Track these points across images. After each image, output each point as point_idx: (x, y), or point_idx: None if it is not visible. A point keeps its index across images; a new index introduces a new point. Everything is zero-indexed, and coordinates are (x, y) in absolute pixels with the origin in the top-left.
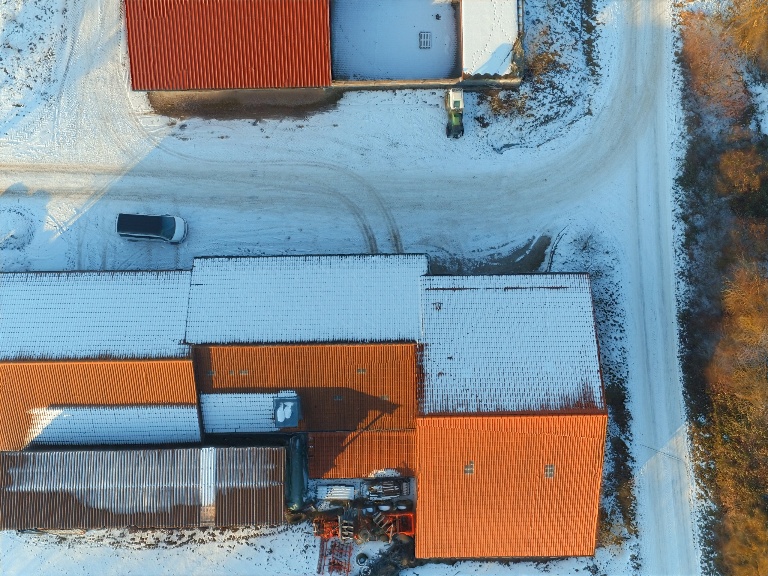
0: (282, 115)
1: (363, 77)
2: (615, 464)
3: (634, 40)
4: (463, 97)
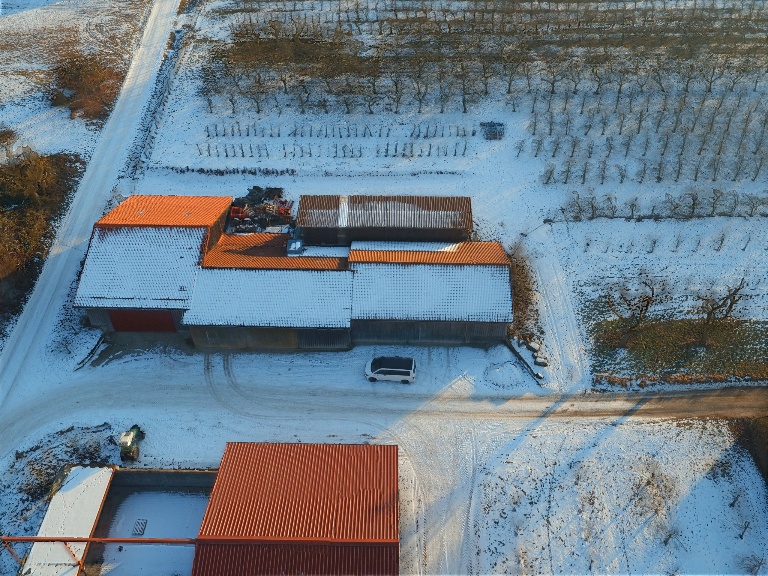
0: None
1: (207, 498)
2: None
3: None
4: None
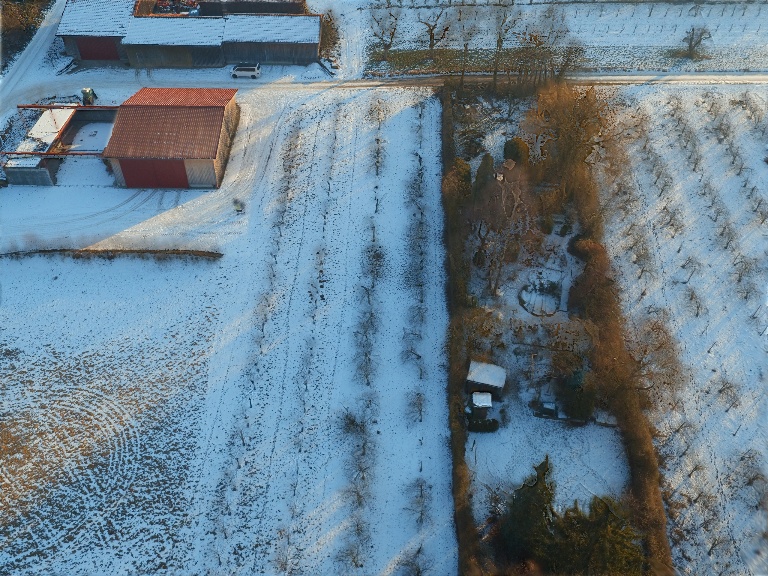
0: None
1: None
2: None
3: None
4: None
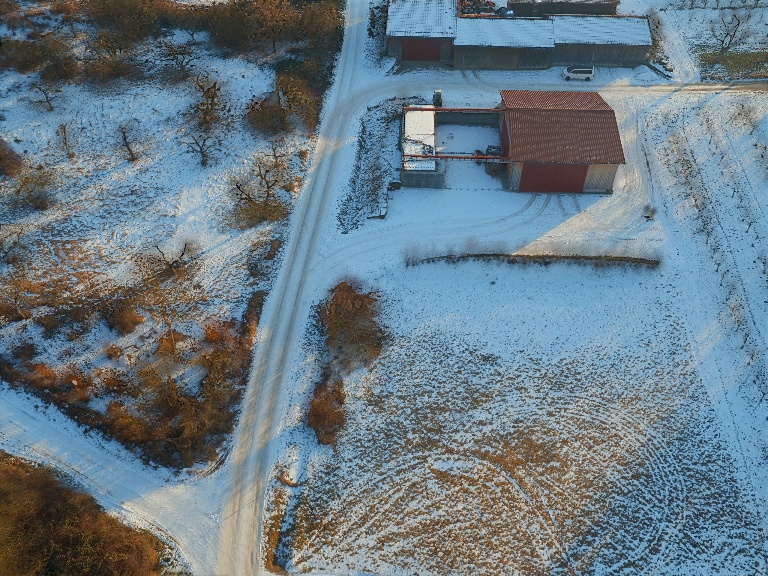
0: None
1: (483, 127)
2: (374, 24)
3: (340, 131)
4: None
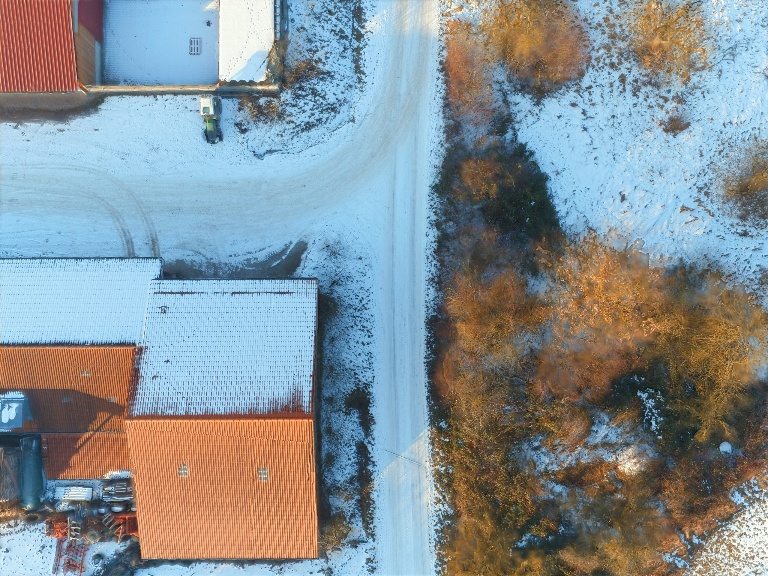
0: (43, 119)
1: (133, 82)
2: (359, 468)
3: (401, 49)
4: (215, 103)
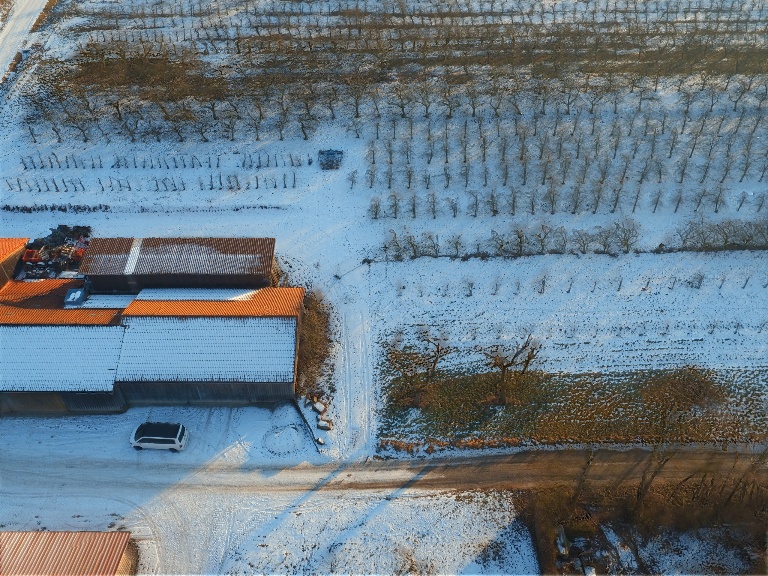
0: None
1: None
2: None
3: None
4: None
